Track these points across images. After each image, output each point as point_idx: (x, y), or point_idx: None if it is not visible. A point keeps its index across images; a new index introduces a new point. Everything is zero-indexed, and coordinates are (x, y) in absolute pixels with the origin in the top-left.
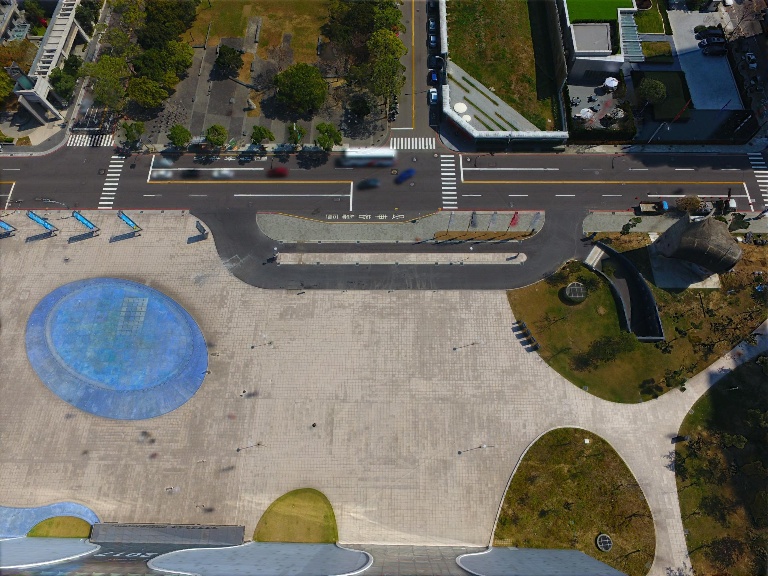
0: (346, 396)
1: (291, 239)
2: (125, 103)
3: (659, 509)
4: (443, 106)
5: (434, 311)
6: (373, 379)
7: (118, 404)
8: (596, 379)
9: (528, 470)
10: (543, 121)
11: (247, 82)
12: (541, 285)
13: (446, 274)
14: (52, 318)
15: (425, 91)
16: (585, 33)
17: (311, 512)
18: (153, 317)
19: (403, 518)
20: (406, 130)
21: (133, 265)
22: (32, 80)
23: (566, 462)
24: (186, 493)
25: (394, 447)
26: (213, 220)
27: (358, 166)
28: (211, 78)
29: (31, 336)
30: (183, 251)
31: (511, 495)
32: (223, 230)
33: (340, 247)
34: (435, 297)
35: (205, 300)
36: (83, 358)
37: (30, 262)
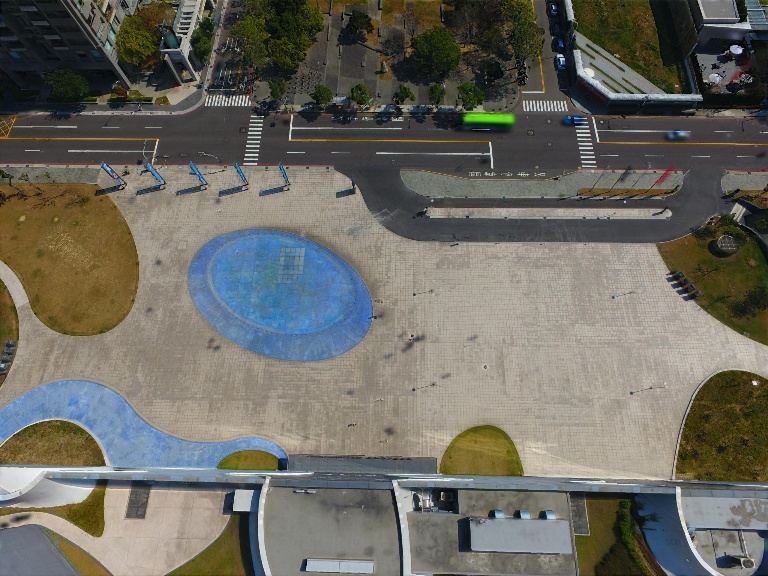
0: (513, 340)
1: (438, 194)
2: (266, 63)
3: None
4: (577, 69)
5: (588, 262)
6: (537, 325)
7: (289, 347)
8: (755, 326)
9: (701, 409)
10: (671, 86)
11: (376, 47)
12: (690, 239)
13: (595, 228)
14: (212, 266)
15: (551, 57)
16: (711, 1)
17: (494, 447)
18: (312, 266)
19: (584, 453)
20: (537, 93)
21: (286, 217)
22: (178, 39)
23: (737, 402)
24: (368, 429)
25: (567, 388)
26: (358, 176)
27: (494, 127)
28: (340, 43)
29: (194, 283)
30: (333, 205)
31: (687, 432)
32: (369, 186)
33: (487, 202)
34: (587, 249)
35: (361, 250)
36: (248, 304)
37: (183, 214)
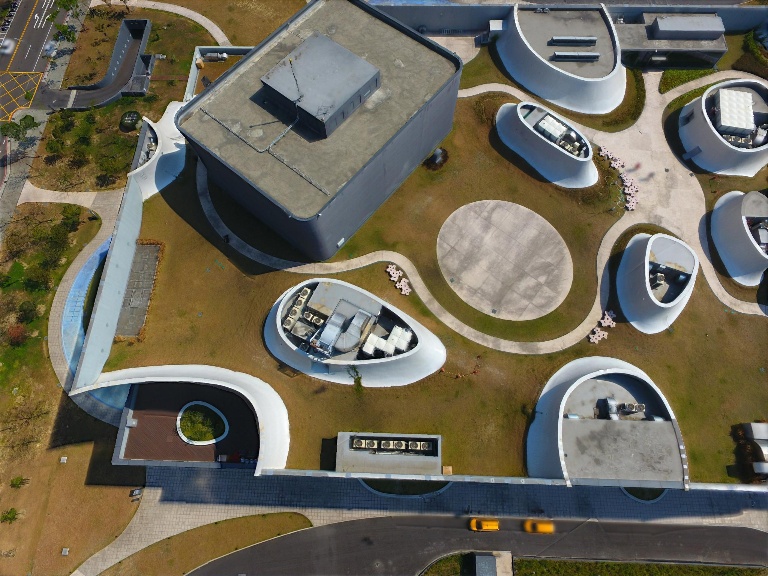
0: None
1: None
2: None
3: None
4: None
5: None
6: None
7: None
8: None
9: None
10: None
11: None
12: (753, 3)
13: None
14: None
15: None
16: None
17: None
18: None
19: None
20: None
21: None
22: None
23: None
24: None
25: None
26: None
27: None
28: None
29: None
30: None
31: None
32: None
33: None
34: None
35: None
36: None
37: None
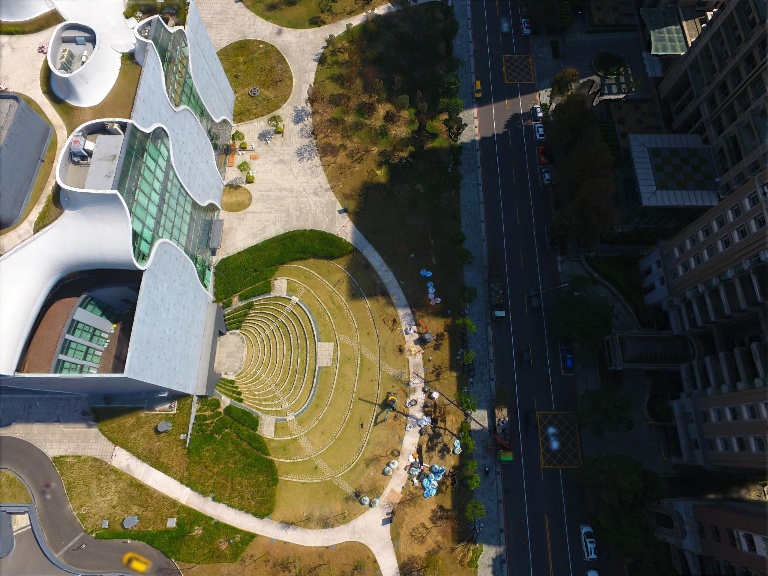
0: None
1: None
2: None
3: (300, 79)
4: None
5: None
6: None
7: None
8: (279, 16)
9: None
10: None
11: None
12: None
13: None
14: None
15: None
16: None
17: None
18: None
19: None
20: None
21: None
22: None
23: (243, 56)
24: None
25: None
26: None
27: None
28: None
29: None
30: None
31: None
32: None
33: None
34: None
35: None
36: None
37: None
